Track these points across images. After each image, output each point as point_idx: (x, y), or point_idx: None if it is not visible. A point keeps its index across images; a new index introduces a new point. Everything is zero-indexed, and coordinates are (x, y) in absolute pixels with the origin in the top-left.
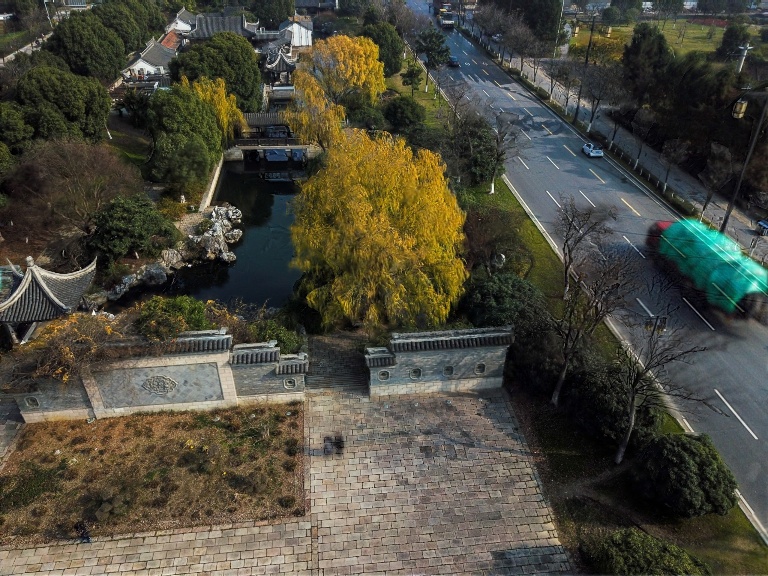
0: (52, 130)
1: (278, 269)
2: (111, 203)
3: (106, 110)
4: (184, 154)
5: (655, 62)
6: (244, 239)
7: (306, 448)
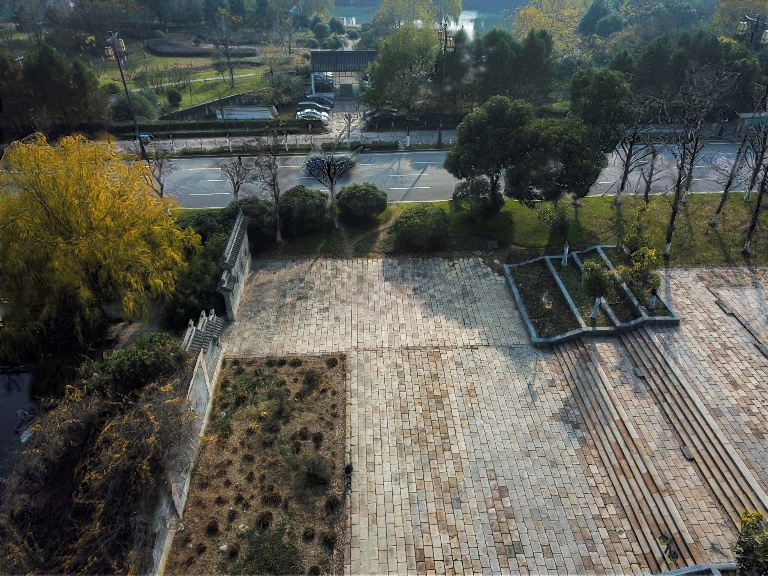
0: None
1: None
2: None
3: None
4: None
5: None
6: None
7: (280, 356)
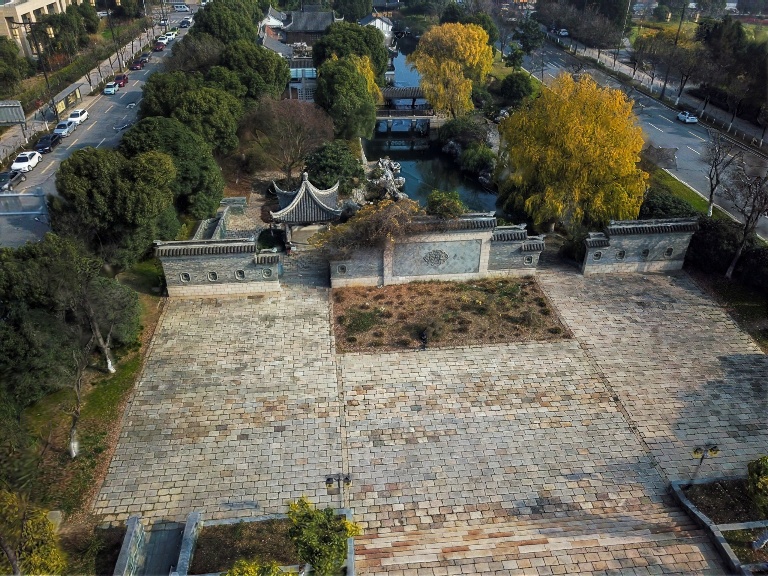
0: (259, 90)
1: None
2: (323, 146)
3: (288, 78)
4: (360, 113)
5: (734, 45)
6: (406, 185)
7: (551, 303)
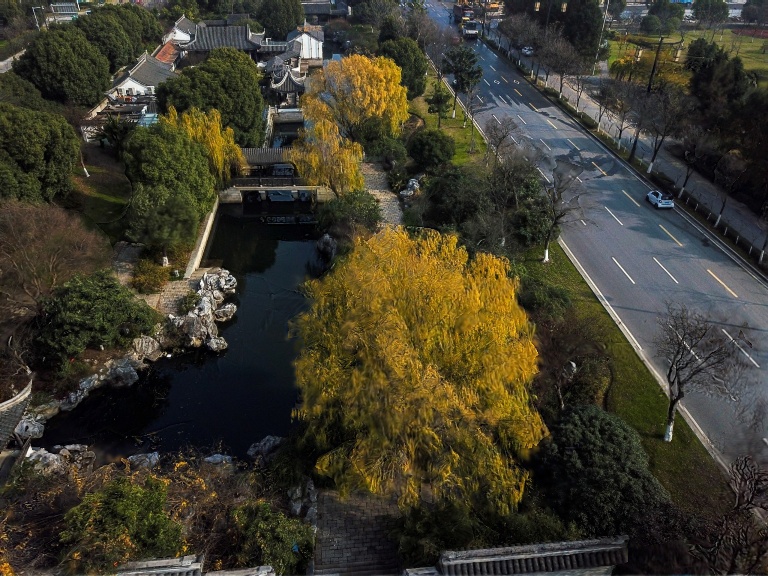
0: None
1: (280, 360)
2: (65, 287)
3: (72, 154)
4: (165, 212)
5: (729, 90)
6: (239, 315)
7: None
